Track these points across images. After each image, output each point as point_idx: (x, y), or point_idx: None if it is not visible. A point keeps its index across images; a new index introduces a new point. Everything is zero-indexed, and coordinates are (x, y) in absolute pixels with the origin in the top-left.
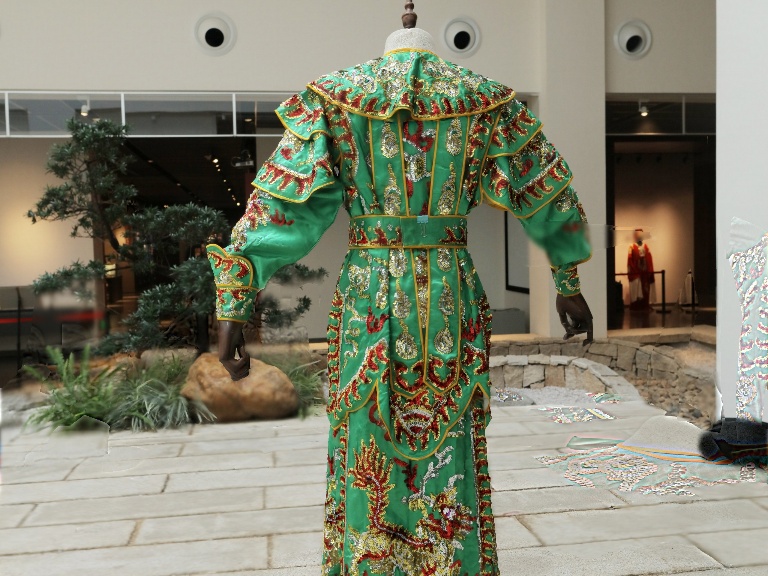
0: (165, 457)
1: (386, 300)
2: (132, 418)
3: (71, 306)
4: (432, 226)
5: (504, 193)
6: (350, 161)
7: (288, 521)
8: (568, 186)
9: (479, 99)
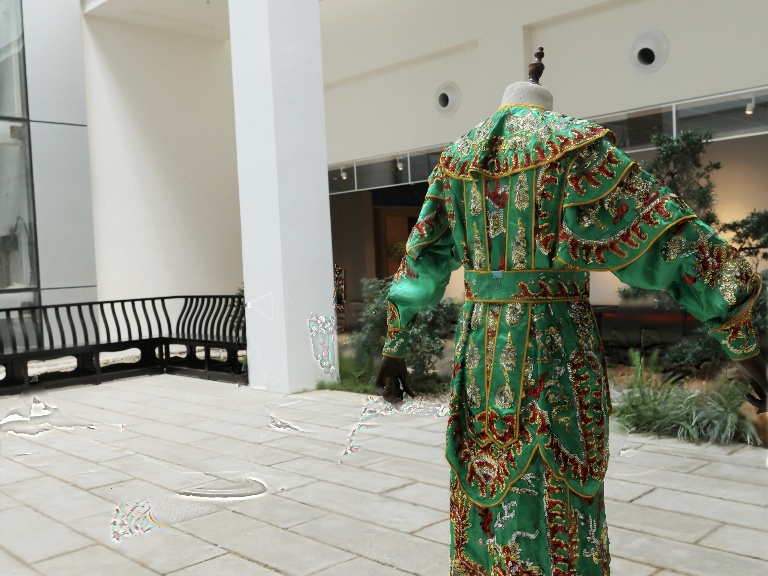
0: (675, 471)
1: (461, 351)
2: (680, 427)
3: (649, 312)
4: (506, 281)
5: (563, 247)
6: (450, 221)
7: (697, 562)
8: (690, 229)
9: (549, 149)
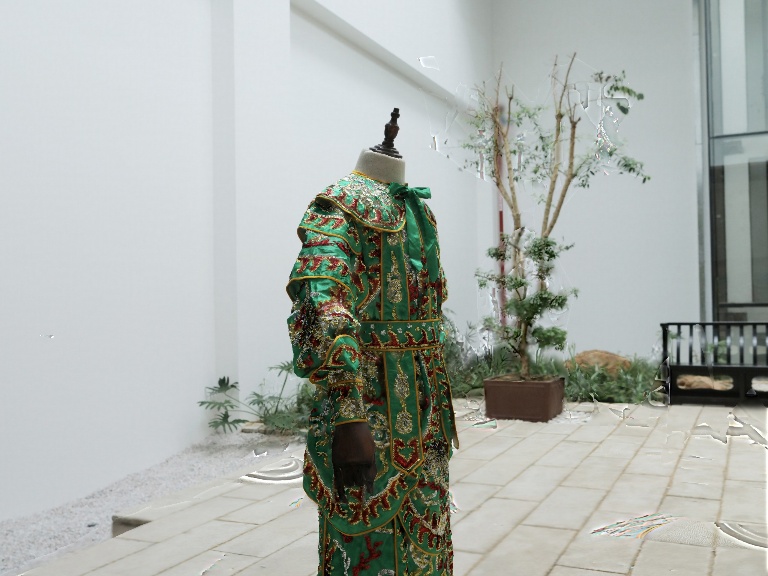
0: None
1: None
2: None
3: None
4: None
5: None
6: None
7: None
8: (304, 290)
9: None
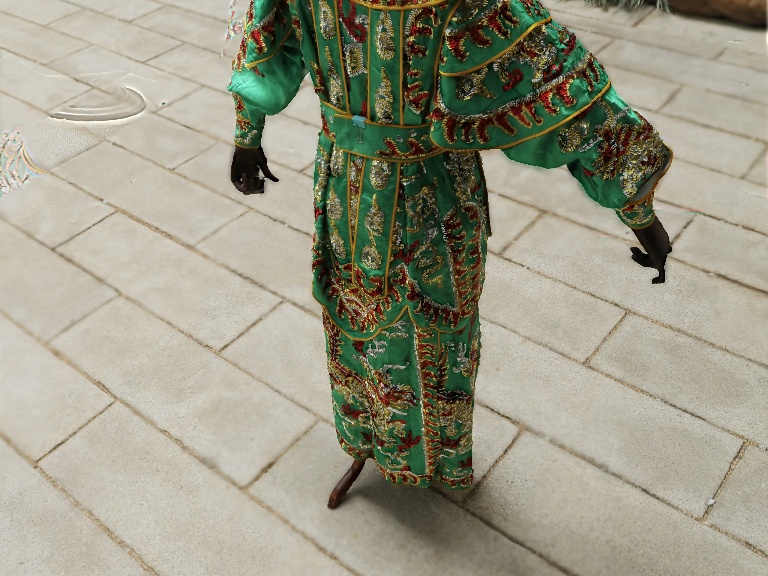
0: None
1: (321, 196)
2: None
3: None
4: (369, 133)
5: (436, 127)
6: (295, 29)
7: (578, 201)
8: (597, 110)
9: None
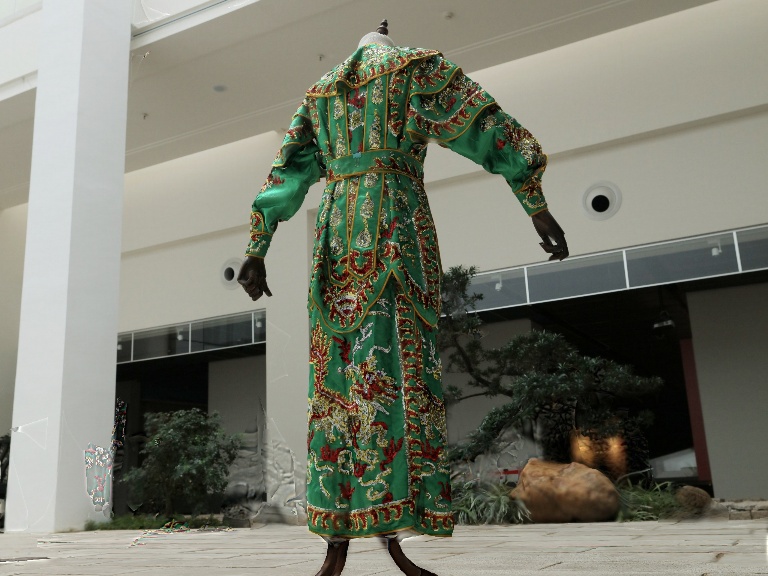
0: (460, 532)
1: (325, 215)
2: (460, 512)
3: None
4: (364, 159)
5: (411, 120)
6: (315, 129)
7: None
8: (499, 114)
9: (398, 61)
